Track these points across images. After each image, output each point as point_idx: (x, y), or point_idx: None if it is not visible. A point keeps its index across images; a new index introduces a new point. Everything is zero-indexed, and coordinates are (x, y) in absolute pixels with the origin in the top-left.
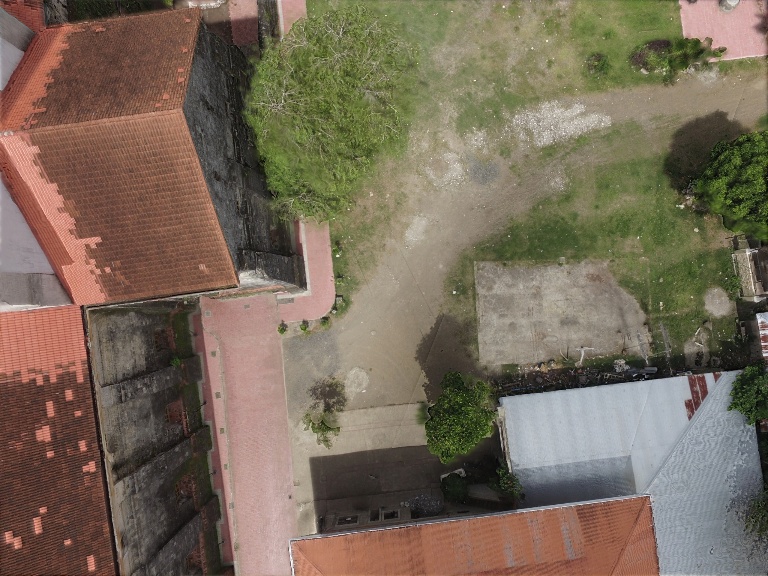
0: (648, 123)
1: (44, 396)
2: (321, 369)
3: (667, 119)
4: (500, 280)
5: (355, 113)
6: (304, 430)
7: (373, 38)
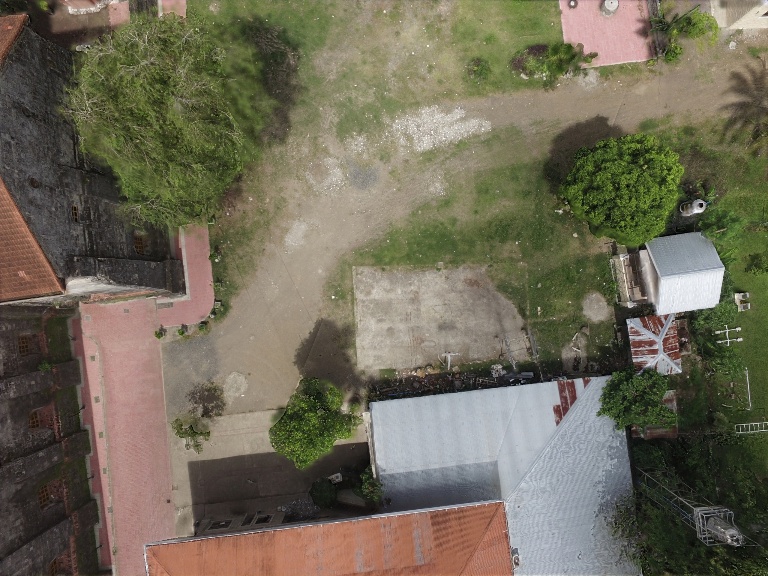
0: (528, 128)
1: None
2: (200, 374)
3: (547, 124)
4: (378, 285)
5: (175, 120)
6: None
7: (190, 46)
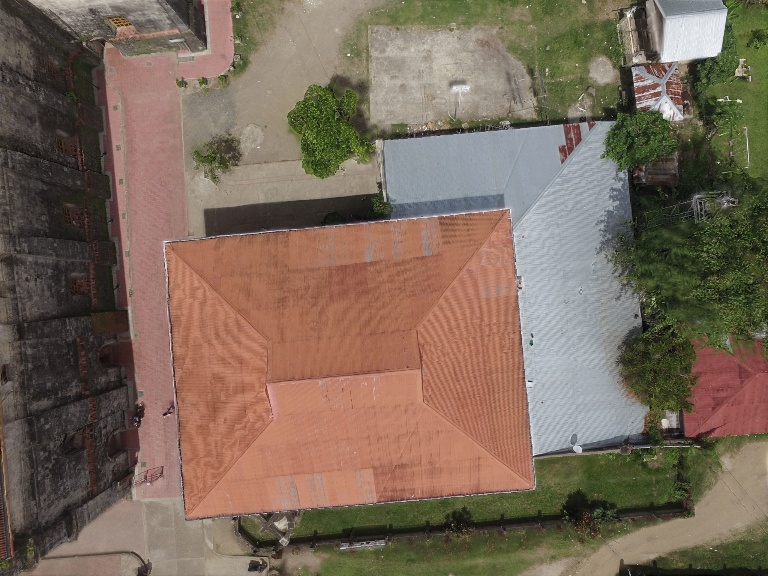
0: None
1: None
2: (218, 125)
3: None
4: (393, 43)
5: None
6: (194, 169)
7: None
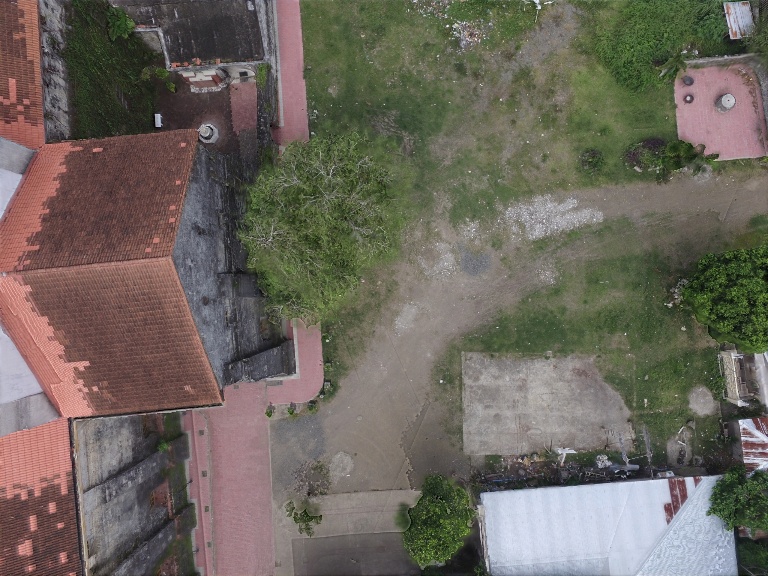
0: (640, 220)
1: (28, 510)
2: (307, 452)
3: (659, 217)
4: (487, 371)
5: (343, 242)
6: (287, 516)
7: (363, 172)
